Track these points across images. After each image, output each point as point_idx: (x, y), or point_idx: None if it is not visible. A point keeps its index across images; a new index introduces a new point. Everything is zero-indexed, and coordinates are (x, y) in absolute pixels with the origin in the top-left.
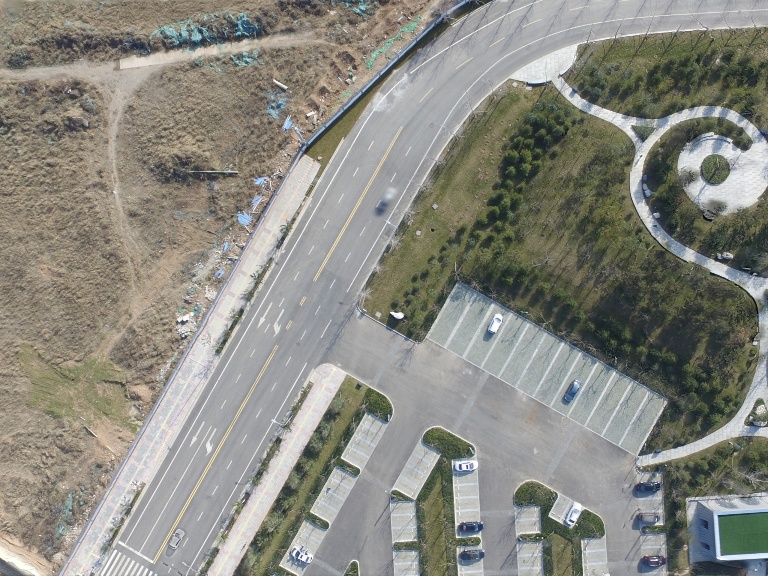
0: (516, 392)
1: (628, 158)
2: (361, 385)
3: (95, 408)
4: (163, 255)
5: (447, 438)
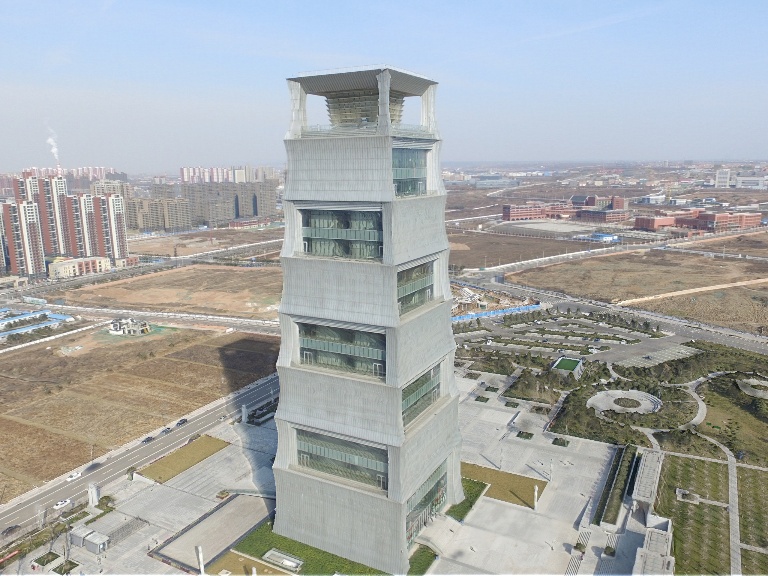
0: (652, 352)
1: (767, 375)
2: (665, 336)
3: (670, 314)
4: None
5: (637, 341)
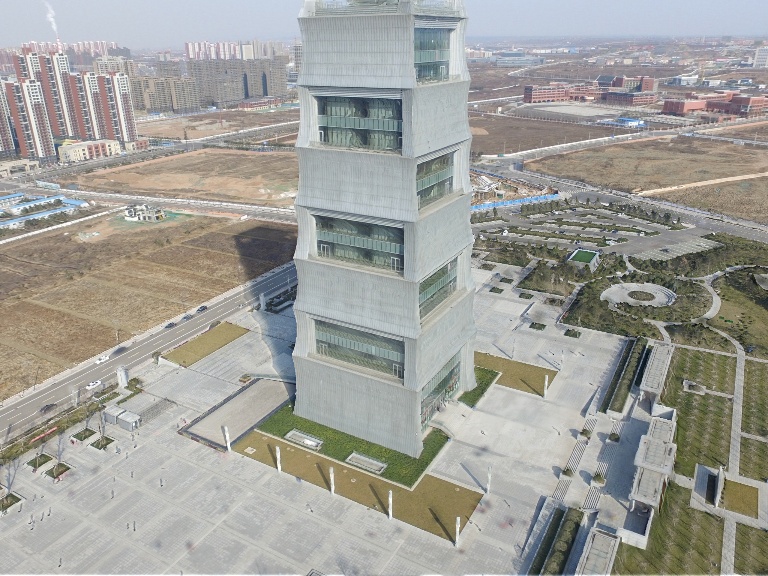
0: None
1: None
2: (685, 228)
3: None
4: (750, 217)
5: (656, 233)
